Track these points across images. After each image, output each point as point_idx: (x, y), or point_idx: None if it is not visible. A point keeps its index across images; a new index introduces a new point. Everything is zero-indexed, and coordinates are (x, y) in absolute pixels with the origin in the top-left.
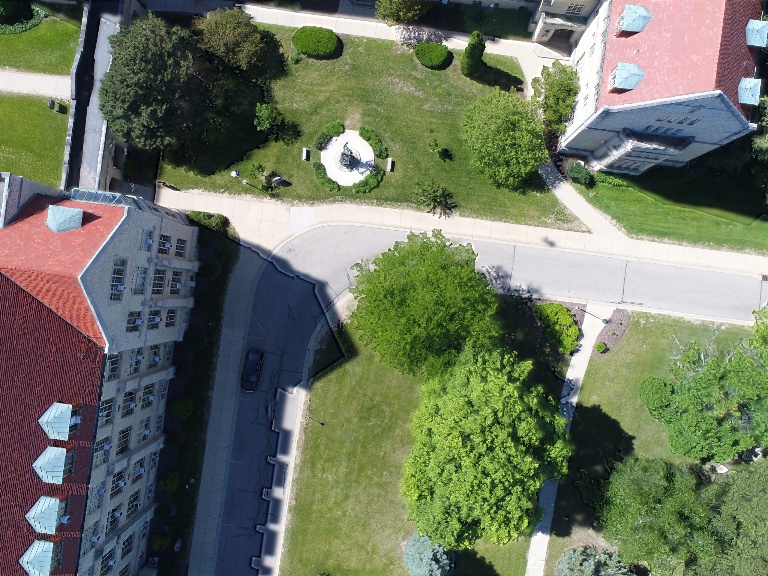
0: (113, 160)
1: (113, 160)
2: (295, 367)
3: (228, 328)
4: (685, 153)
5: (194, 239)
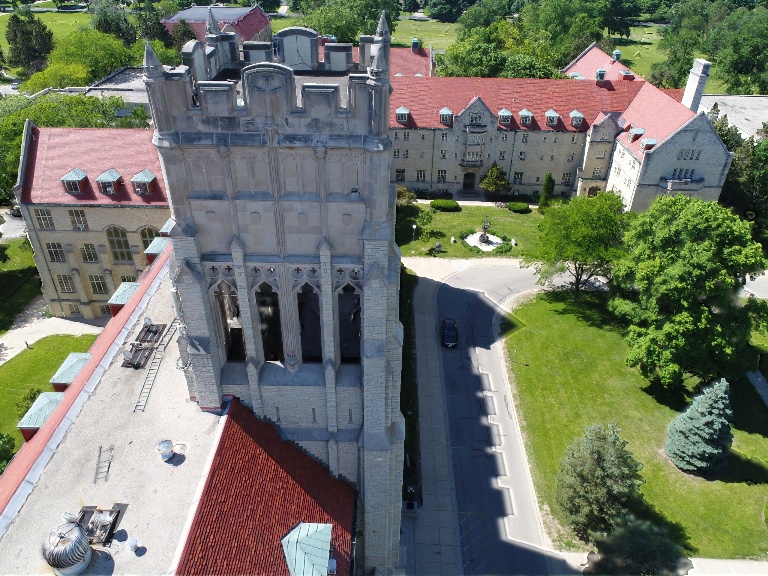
0: None
1: None
2: (486, 334)
3: (420, 315)
4: None
5: None
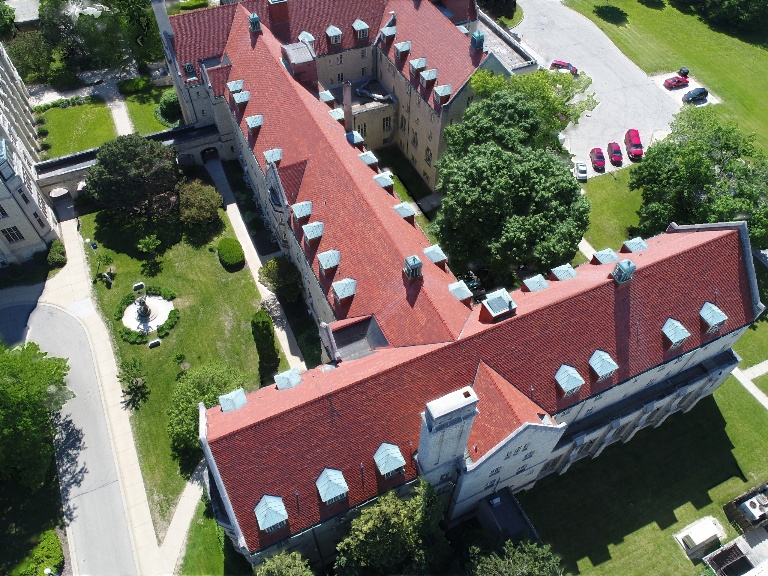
0: None
1: None
2: None
3: None
4: None
5: (34, 248)
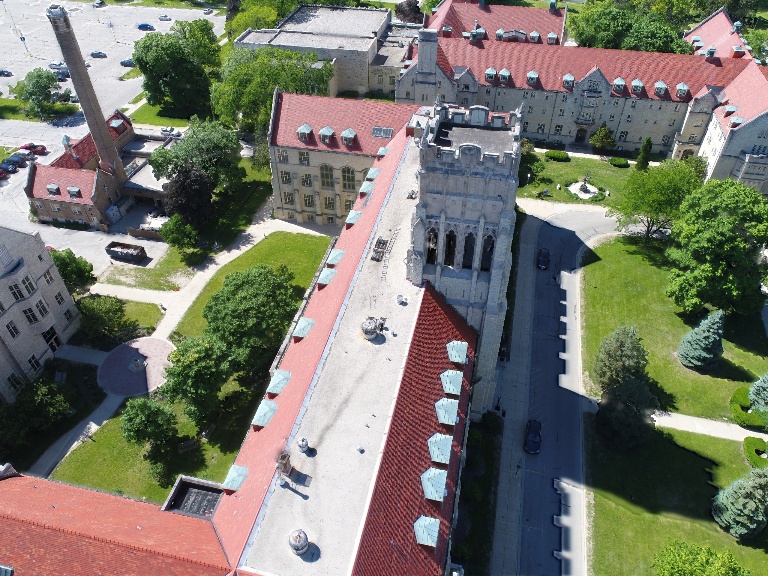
0: None
1: None
2: (570, 262)
3: (524, 244)
4: None
5: None
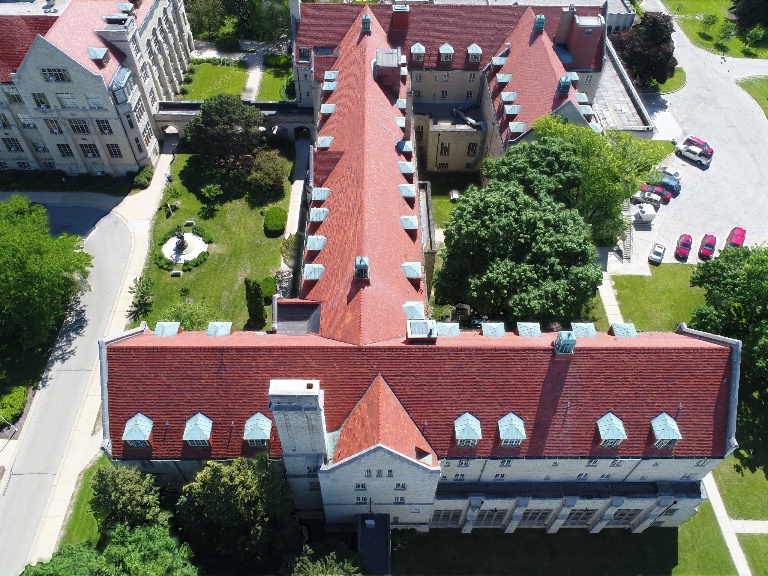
0: None
1: None
2: None
3: (63, 195)
4: None
5: (128, 167)
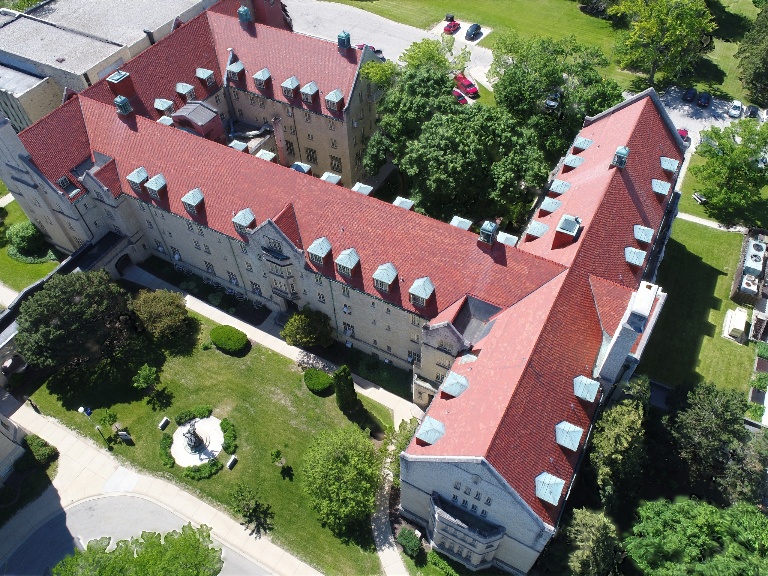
0: (10, 369)
1: (10, 369)
2: None
3: None
4: (516, 557)
5: (11, 458)
